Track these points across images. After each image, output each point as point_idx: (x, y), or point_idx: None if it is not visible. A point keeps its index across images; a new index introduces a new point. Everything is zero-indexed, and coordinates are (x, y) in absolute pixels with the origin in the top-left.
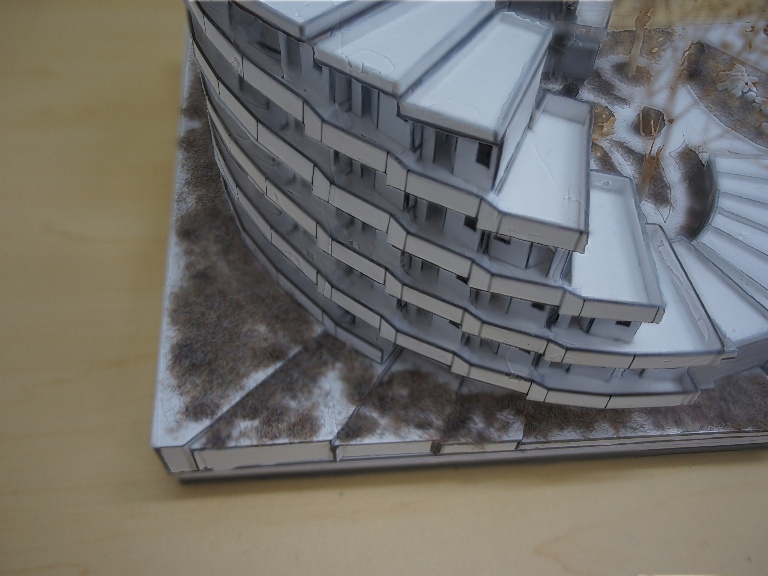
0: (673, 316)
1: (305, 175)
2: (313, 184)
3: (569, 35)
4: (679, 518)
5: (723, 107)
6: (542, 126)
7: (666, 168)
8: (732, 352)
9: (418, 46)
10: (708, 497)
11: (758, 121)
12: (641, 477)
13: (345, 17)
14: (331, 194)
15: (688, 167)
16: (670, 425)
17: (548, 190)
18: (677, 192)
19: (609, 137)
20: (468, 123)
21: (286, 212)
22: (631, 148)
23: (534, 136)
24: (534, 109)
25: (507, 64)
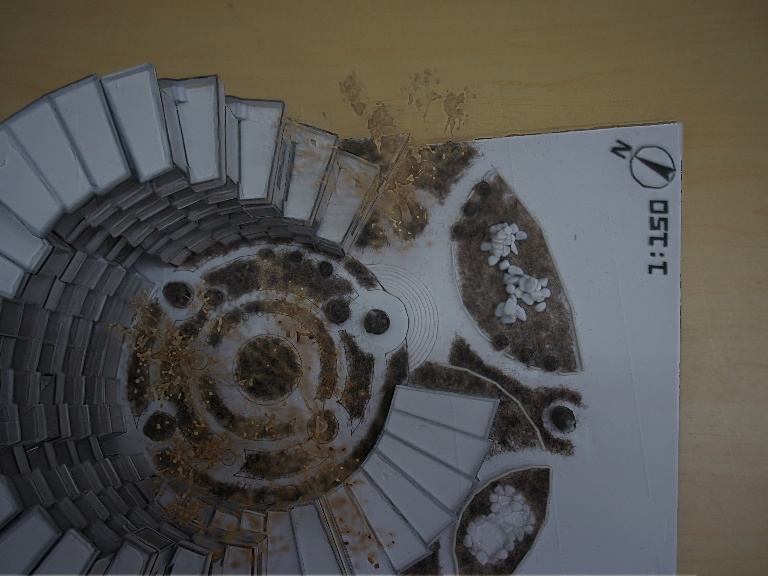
0: None
1: None
2: None
3: (314, 239)
4: None
5: (475, 275)
6: (127, 554)
7: (376, 372)
8: None
9: None
10: None
11: (499, 297)
12: None
13: None
14: None
15: (391, 377)
16: None
17: None
18: (373, 402)
19: (343, 328)
20: None
21: None
22: (357, 344)
23: (118, 564)
24: (111, 559)
25: None
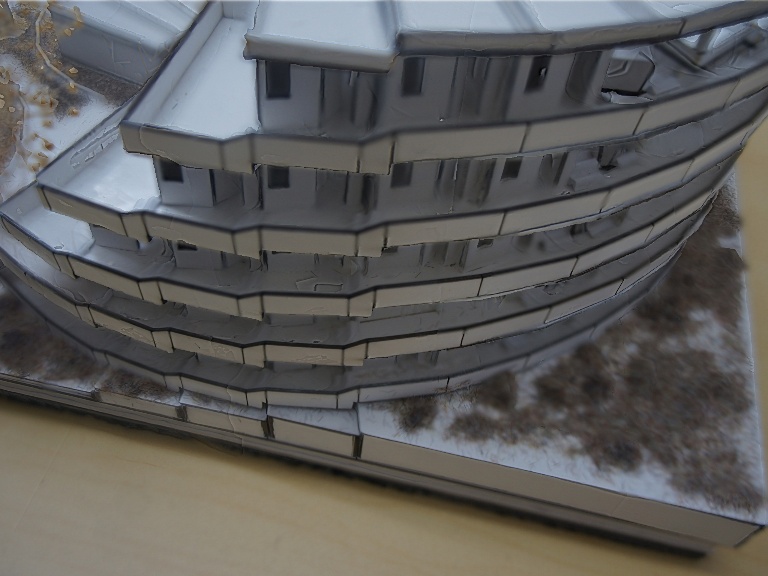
0: None
1: None
2: None
3: None
4: None
5: None
6: None
7: None
8: None
9: None
10: None
11: None
12: None
13: None
14: None
15: None
16: None
17: None
18: None
19: None
20: None
21: None
22: None
23: None
24: None
25: None
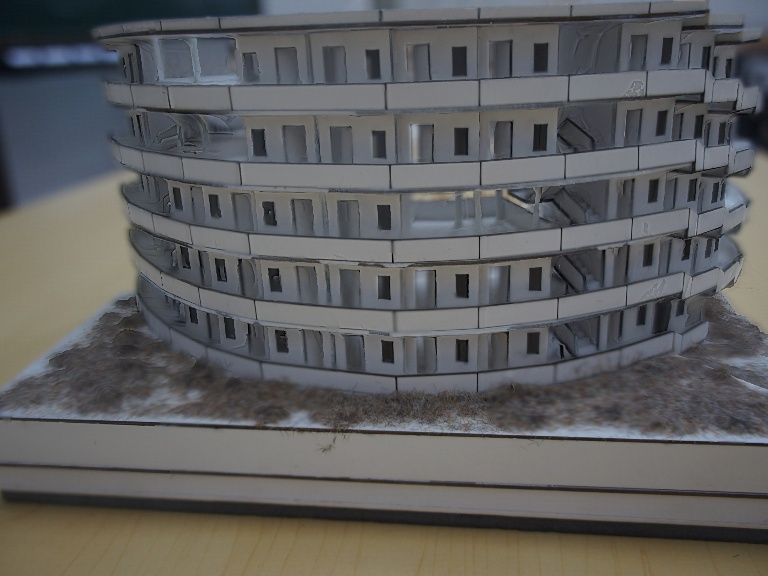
0: None
1: (688, 159)
2: (697, 159)
3: None
4: None
5: None
6: None
7: None
8: None
9: None
10: None
11: None
12: None
13: None
14: (705, 158)
15: None
16: None
17: None
18: None
19: None
20: (721, 54)
21: (656, 234)
22: None
23: None
24: None
25: None
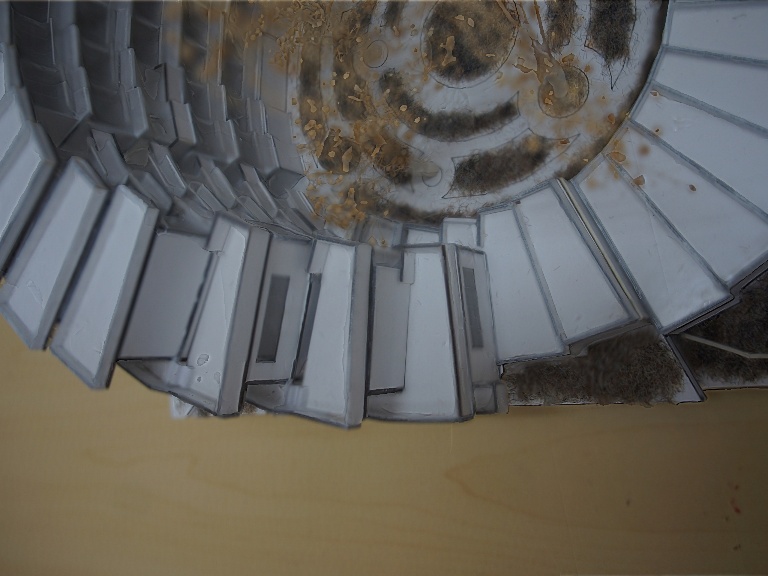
0: (446, 359)
1: None
2: None
3: None
4: (569, 458)
5: None
6: (232, 243)
7: None
8: (558, 355)
9: (50, 280)
10: (605, 439)
11: None
12: (543, 415)
13: (2, 263)
14: None
15: None
16: (533, 396)
17: (221, 341)
18: (642, 24)
19: None
20: None
21: None
22: None
23: (223, 261)
24: (204, 246)
25: (119, 271)
